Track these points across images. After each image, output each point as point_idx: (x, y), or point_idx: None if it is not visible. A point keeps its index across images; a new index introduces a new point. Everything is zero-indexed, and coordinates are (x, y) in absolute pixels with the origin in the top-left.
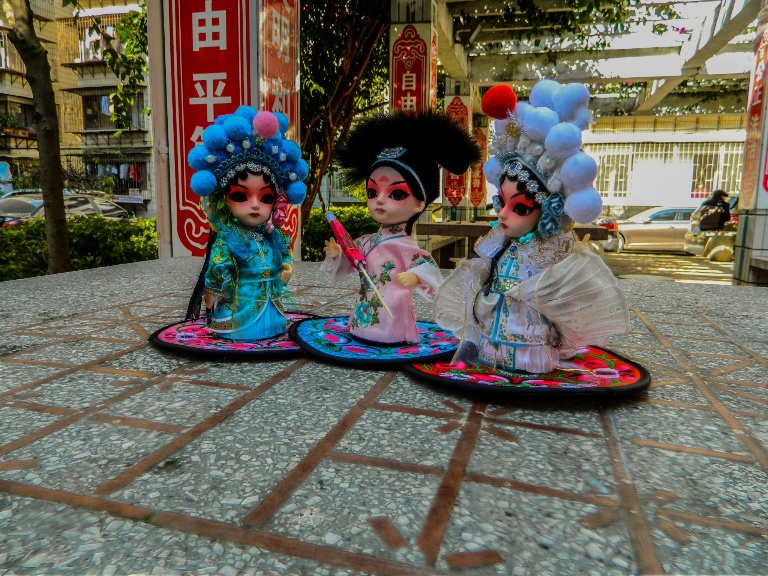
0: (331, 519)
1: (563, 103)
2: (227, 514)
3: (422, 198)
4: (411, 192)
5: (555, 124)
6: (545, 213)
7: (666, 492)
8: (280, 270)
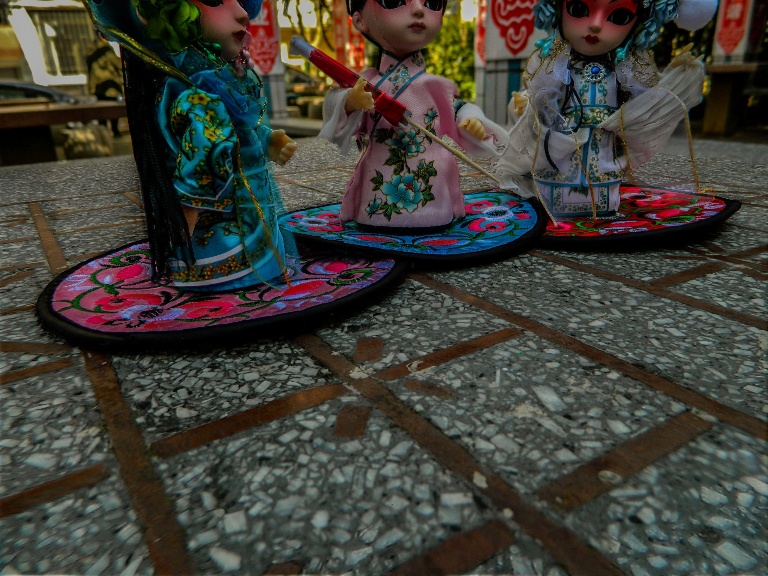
0: None
1: None
2: None
3: None
4: None
5: None
6: (652, 19)
7: None
8: None
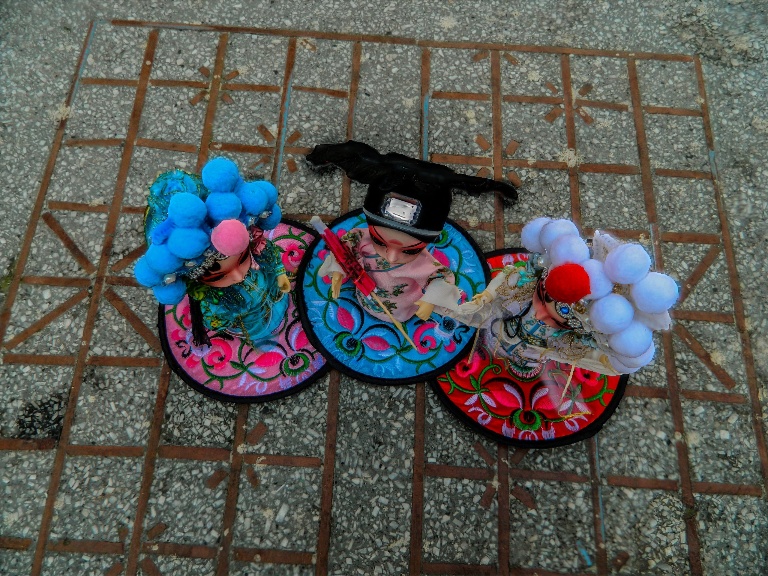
0: None
1: None
2: None
3: None
4: (428, 243)
5: (628, 326)
6: None
7: (623, 553)
8: (274, 281)
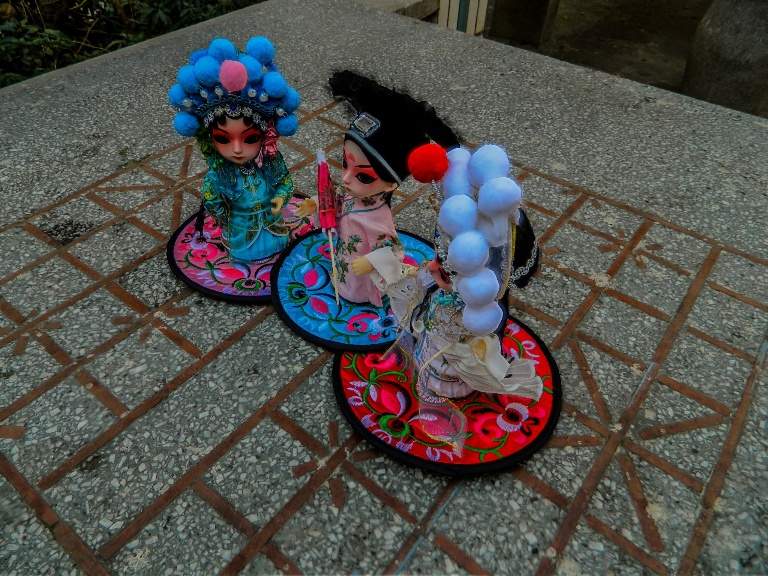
0: (149, 567)
1: (480, 207)
2: (95, 538)
3: (393, 180)
4: (379, 176)
5: (466, 229)
6: None
7: None
8: None
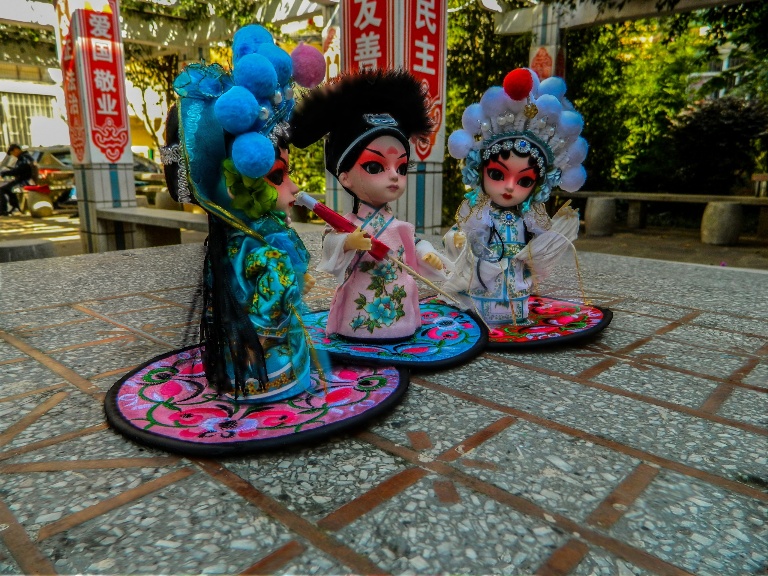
0: None
1: (559, 94)
2: None
3: None
4: None
5: None
6: (545, 184)
7: (732, 347)
8: None
